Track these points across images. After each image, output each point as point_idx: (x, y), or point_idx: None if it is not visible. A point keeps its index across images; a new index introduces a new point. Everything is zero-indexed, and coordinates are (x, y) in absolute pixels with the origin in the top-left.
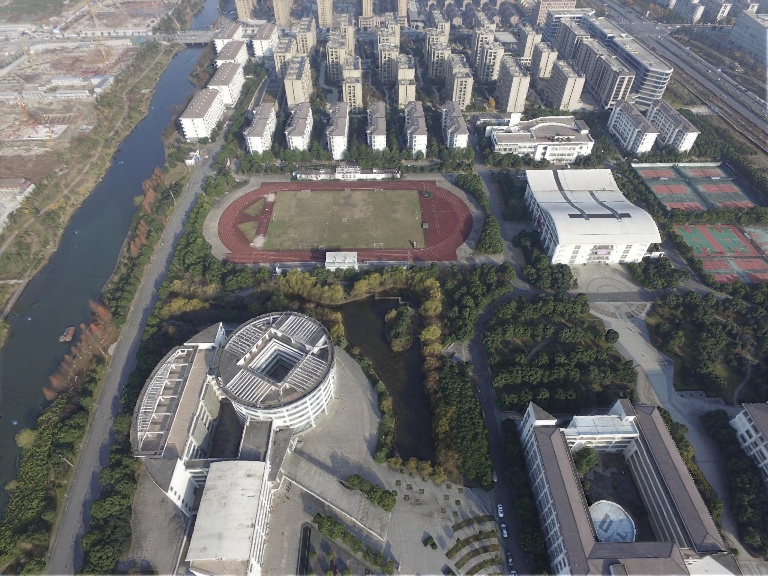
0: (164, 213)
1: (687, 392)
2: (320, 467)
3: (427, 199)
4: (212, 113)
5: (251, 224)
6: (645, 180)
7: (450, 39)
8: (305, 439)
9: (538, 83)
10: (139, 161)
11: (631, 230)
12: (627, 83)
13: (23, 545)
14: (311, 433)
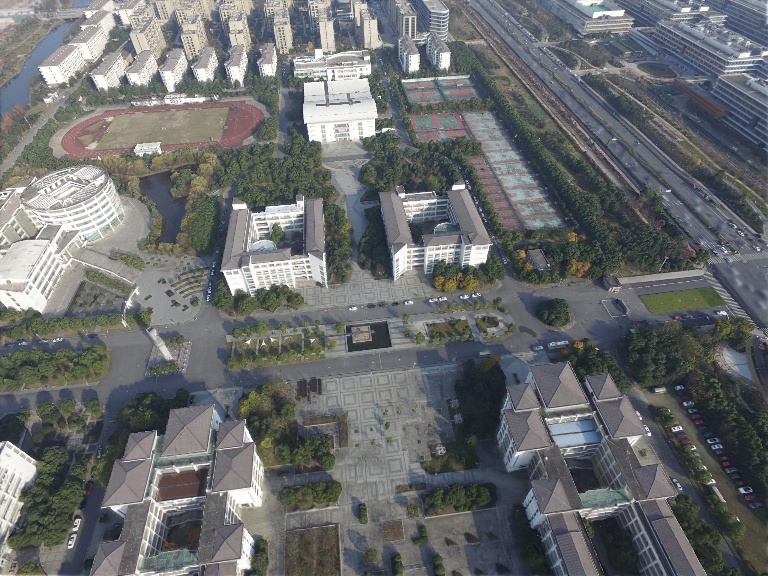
0: (20, 134)
1: (367, 201)
2: None
3: (234, 112)
4: (69, 64)
5: (89, 136)
6: (408, 90)
7: (299, 3)
8: (95, 244)
9: (355, 30)
10: (8, 105)
11: (357, 110)
12: (412, 23)
13: None
14: (100, 241)
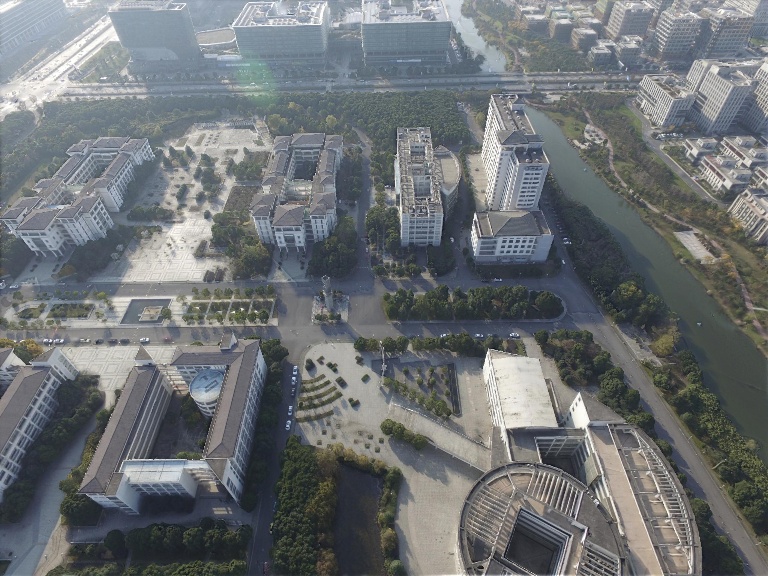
0: None
1: None
2: (456, 465)
3: None
4: None
5: None
6: None
7: None
8: None
9: None
10: None
11: None
12: None
13: (683, 390)
14: None
